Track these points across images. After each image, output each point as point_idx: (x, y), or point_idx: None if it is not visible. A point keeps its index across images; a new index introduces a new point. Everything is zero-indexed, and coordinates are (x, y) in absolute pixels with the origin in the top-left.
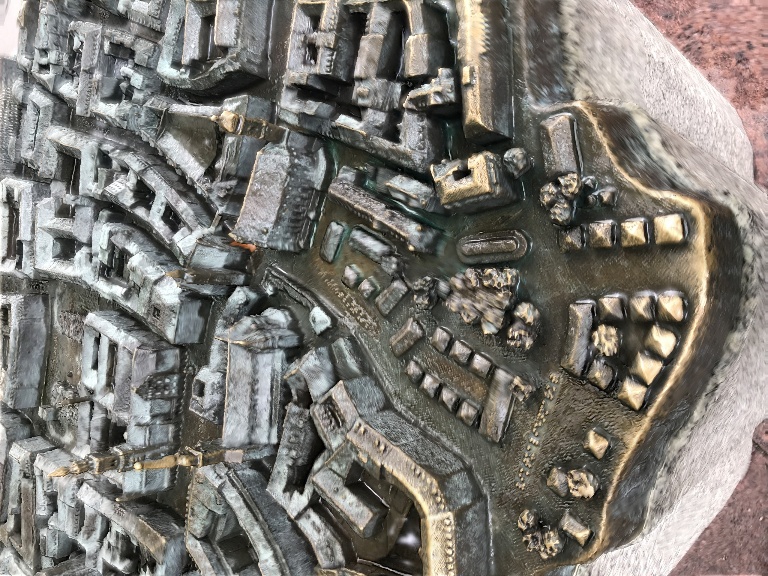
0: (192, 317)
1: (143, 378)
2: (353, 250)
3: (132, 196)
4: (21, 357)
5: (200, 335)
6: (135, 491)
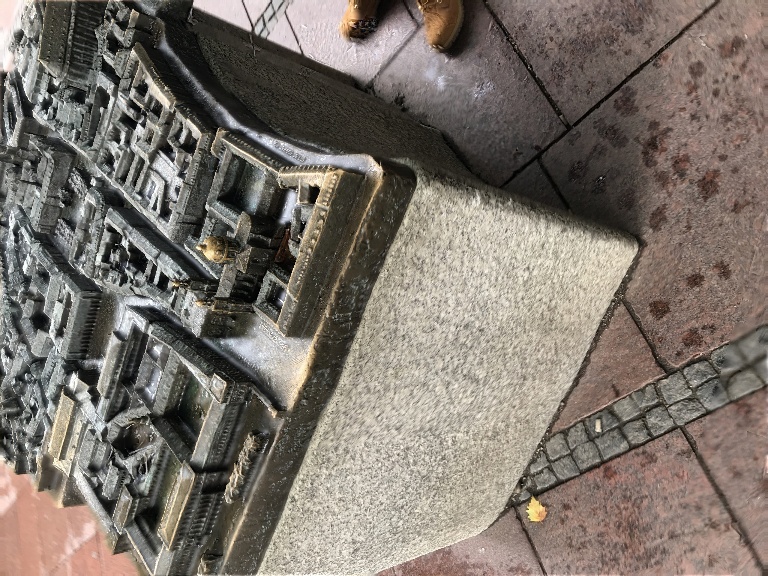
0: None
1: None
2: None
3: None
4: None
5: None
6: None
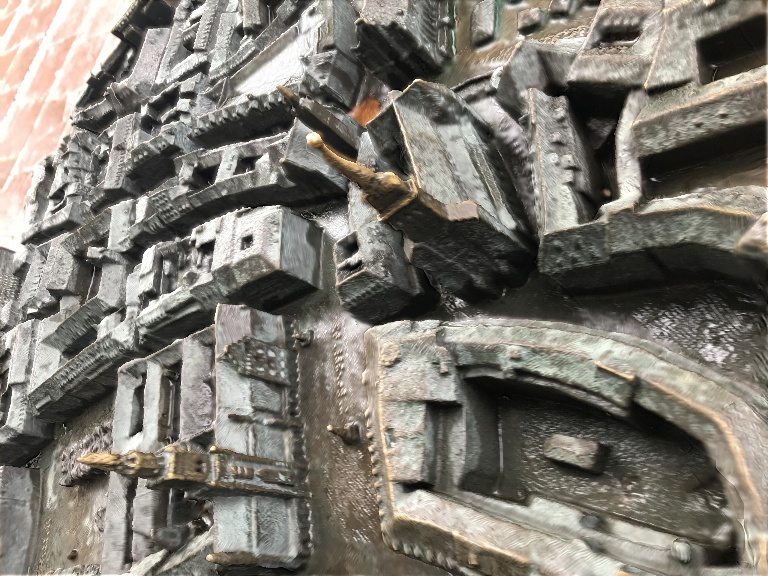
0: (299, 241)
1: None
2: (517, 5)
3: (187, 190)
4: None
5: (313, 274)
6: (240, 550)
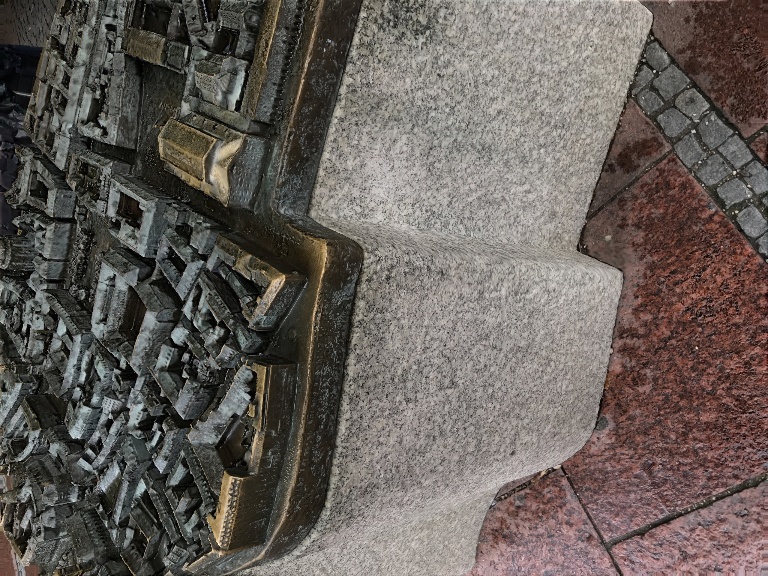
0: None
1: None
2: None
3: None
4: None
5: None
6: None
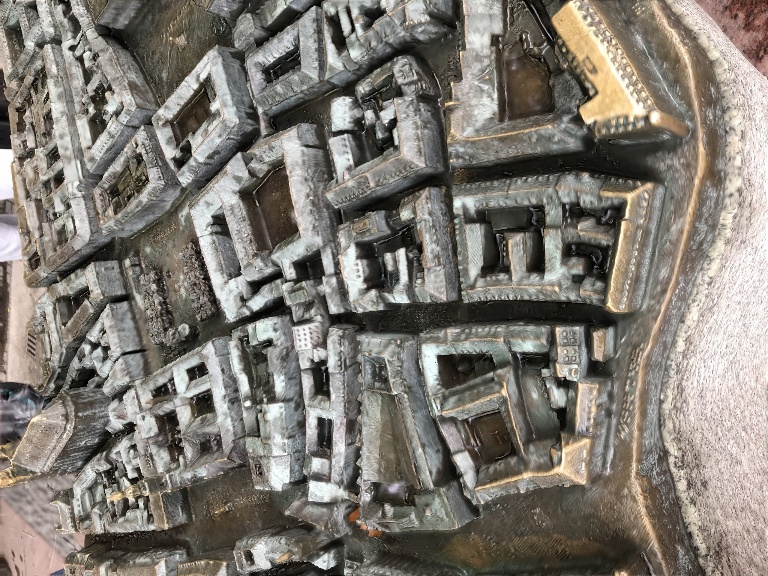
0: None
1: (218, 467)
2: None
3: (311, 358)
4: (134, 217)
5: None
6: None
